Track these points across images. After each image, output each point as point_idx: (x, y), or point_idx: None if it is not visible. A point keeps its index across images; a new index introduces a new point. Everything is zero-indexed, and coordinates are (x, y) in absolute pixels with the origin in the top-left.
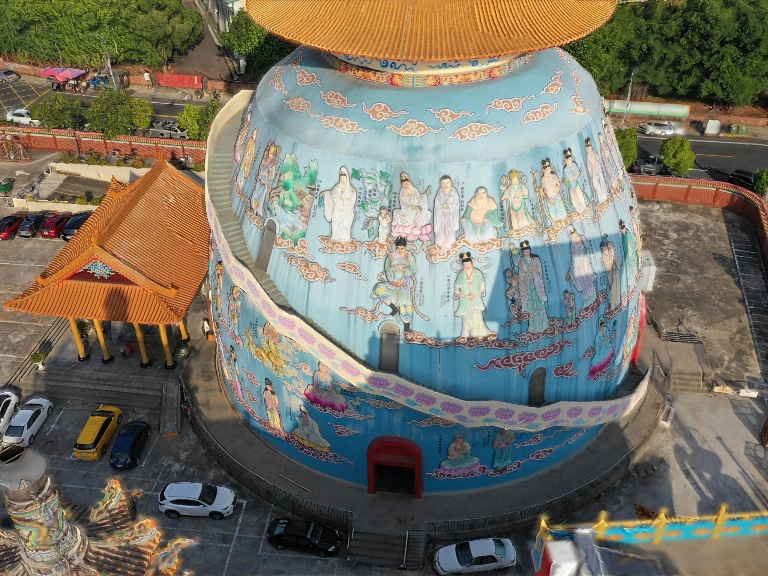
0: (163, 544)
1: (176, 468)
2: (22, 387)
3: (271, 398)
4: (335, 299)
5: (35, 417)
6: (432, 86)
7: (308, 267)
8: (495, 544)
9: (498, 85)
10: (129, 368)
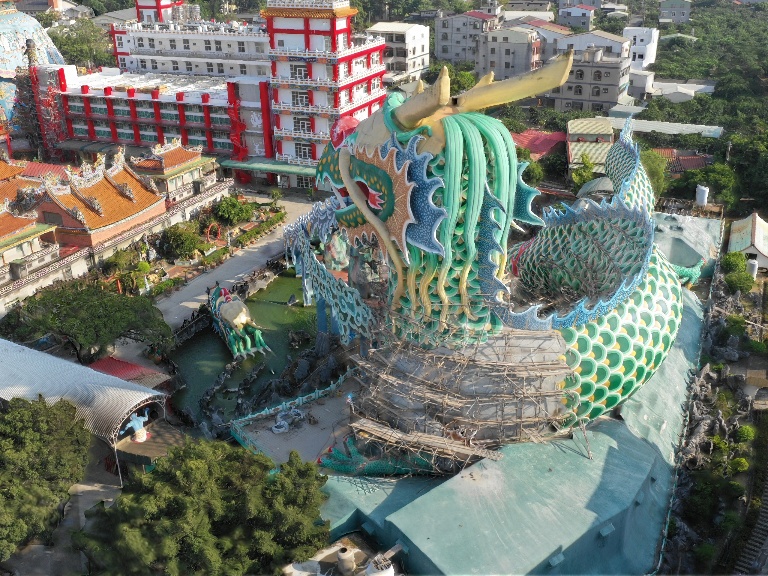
0: None
1: None
2: None
3: (2, 109)
4: (14, 66)
5: None
6: (6, 14)
7: (3, 60)
8: None
9: (19, 13)
10: None
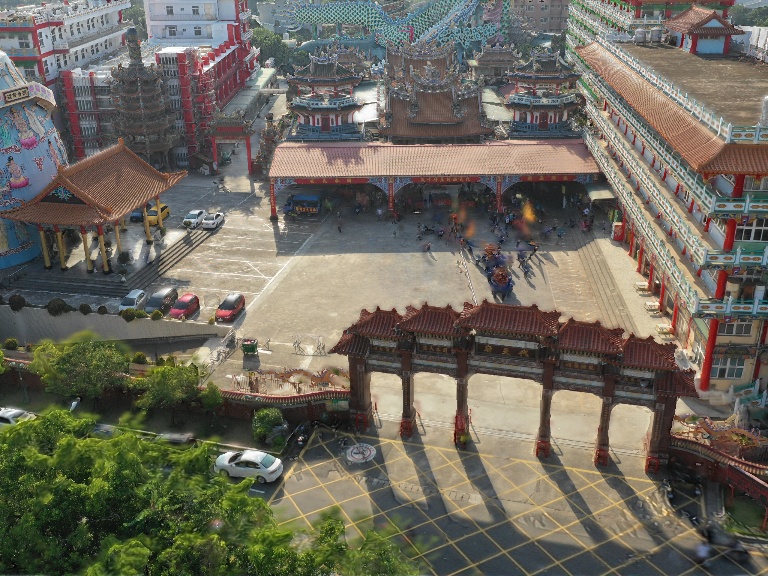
0: (112, 79)
1: None
2: None
3: None
4: None
5: None
6: None
7: None
8: None
9: None
10: (135, 230)
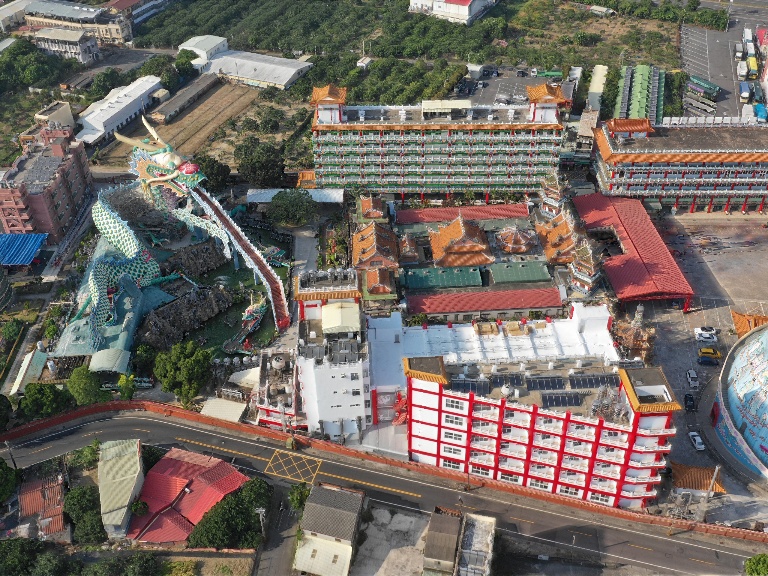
0: None
1: (705, 374)
2: (721, 333)
3: None
4: None
5: (708, 338)
6: None
7: None
8: (701, 442)
9: None
10: None
